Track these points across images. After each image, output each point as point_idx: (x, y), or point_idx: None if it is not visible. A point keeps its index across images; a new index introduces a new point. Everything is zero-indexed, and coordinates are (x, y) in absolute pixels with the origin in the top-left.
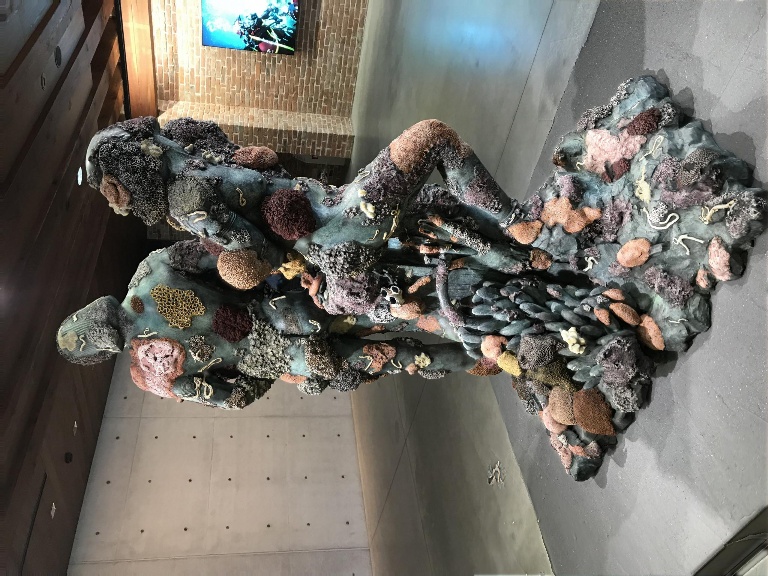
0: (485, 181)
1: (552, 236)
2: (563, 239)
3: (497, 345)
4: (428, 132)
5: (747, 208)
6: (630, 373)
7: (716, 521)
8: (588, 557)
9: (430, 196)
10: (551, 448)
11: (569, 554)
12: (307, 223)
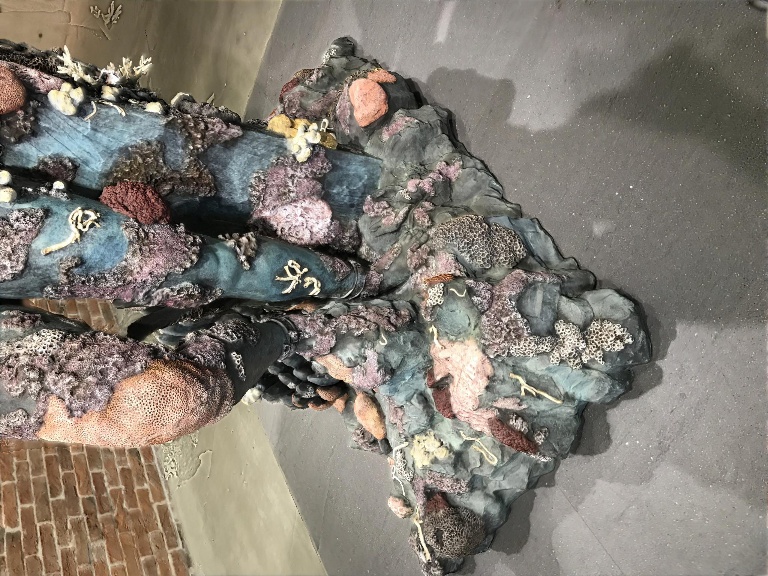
0: None
1: None
2: None
3: None
4: None
5: (425, 571)
6: None
7: (276, 435)
8: None
9: (155, 299)
10: None
11: None
12: None
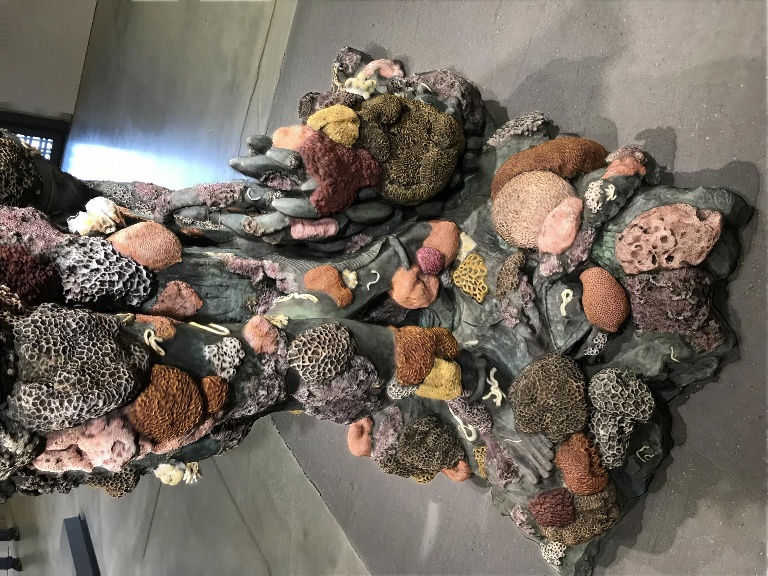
0: None
1: None
2: None
3: None
4: None
5: None
6: None
7: None
8: None
9: None
10: None
11: None
12: None
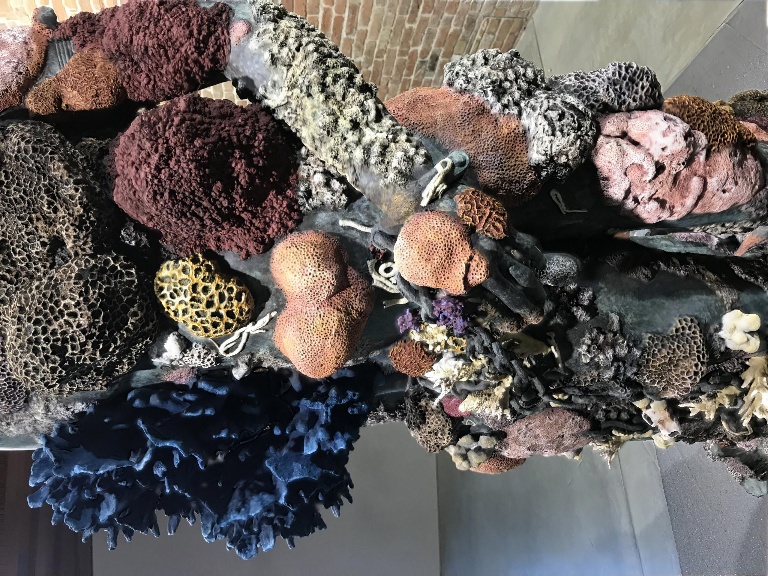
0: None
1: None
2: None
3: None
4: None
5: None
6: None
7: None
8: None
9: None
10: None
11: None
12: None
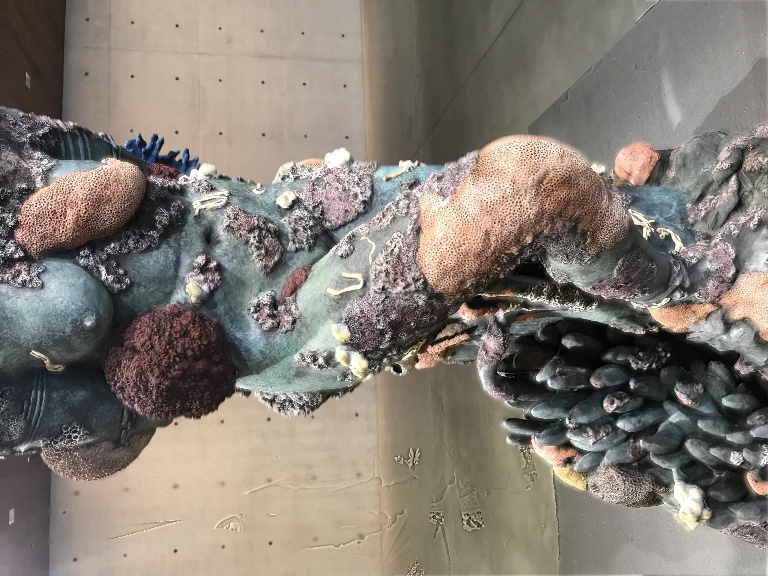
0: (632, 278)
1: (727, 334)
2: (747, 348)
3: (560, 459)
4: (527, 210)
5: None
6: (762, 547)
7: None
8: (599, 524)
9: None
10: None
11: (578, 495)
12: (212, 403)
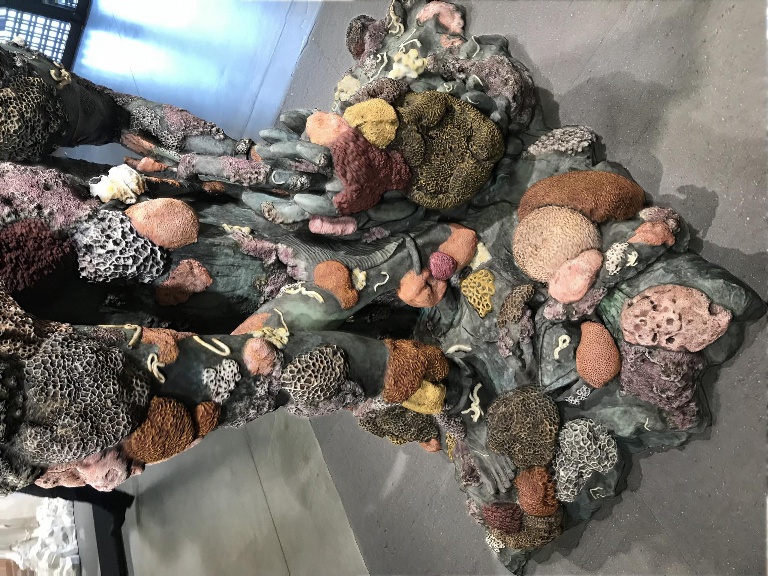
0: None
1: None
2: None
3: None
4: None
5: None
6: (499, 56)
7: None
8: None
9: None
10: (733, 512)
11: None
12: None
